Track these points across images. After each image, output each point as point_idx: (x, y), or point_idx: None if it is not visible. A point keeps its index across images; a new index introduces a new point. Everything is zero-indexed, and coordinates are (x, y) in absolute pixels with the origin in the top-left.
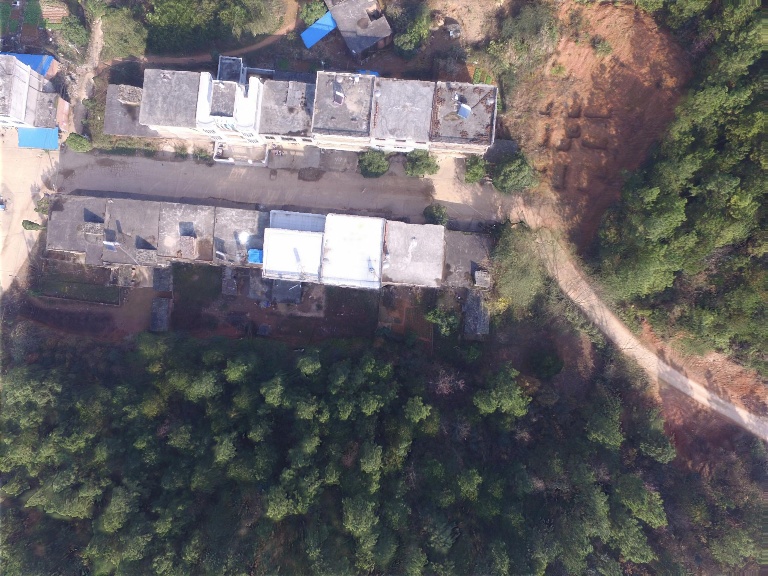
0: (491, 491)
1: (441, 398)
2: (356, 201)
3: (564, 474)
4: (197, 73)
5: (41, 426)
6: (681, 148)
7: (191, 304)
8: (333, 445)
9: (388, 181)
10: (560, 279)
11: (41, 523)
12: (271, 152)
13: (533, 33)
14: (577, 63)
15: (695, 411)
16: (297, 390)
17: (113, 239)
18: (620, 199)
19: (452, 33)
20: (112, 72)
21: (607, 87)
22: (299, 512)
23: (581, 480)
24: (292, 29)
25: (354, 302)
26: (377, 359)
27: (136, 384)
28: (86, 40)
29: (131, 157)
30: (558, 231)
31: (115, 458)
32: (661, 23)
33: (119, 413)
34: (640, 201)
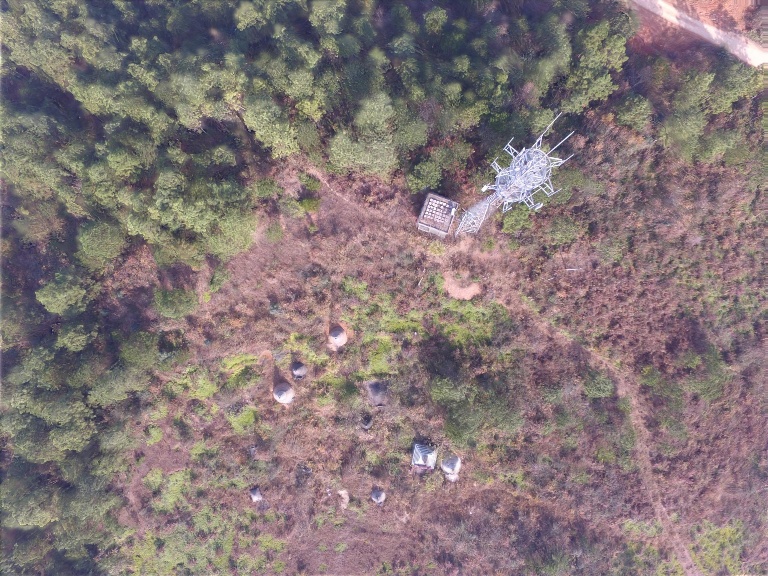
0: (455, 24)
1: None
2: None
3: (529, 31)
4: None
5: (26, 1)
6: None
7: None
8: None
9: None
10: None
11: (25, 89)
12: None
13: None
14: None
15: (664, 29)
16: None
17: None
18: None
19: None
20: None
21: None
22: (268, 20)
23: (545, 35)
24: None
25: None
26: None
27: None
28: None
29: None
30: None
31: (95, 20)
32: None
33: None
34: None
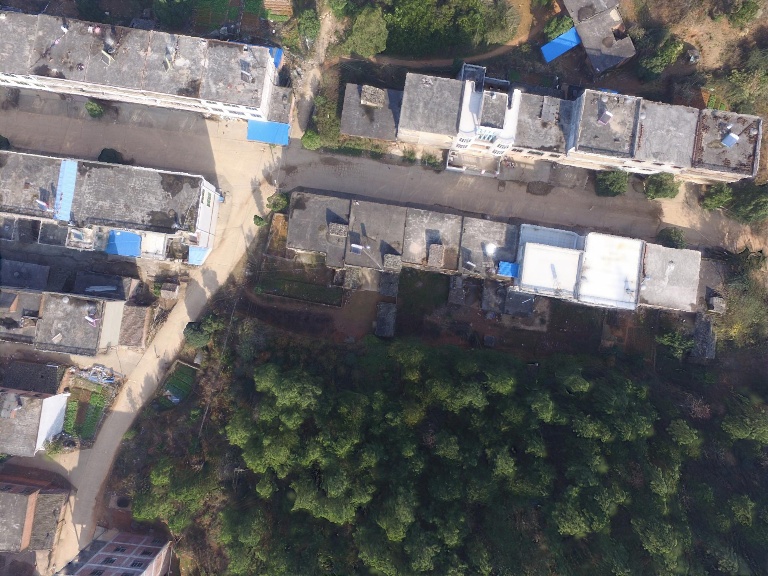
0: (763, 517)
1: (697, 422)
2: (583, 218)
3: None
4: (460, 81)
5: (299, 429)
6: None
7: (414, 310)
8: (618, 465)
9: (617, 200)
10: None
11: (297, 526)
12: (501, 163)
13: None
14: None
15: None
16: (565, 407)
17: (357, 242)
18: None
19: (693, 59)
20: (342, 70)
21: None
22: (593, 531)
23: None
24: (525, 41)
25: (578, 319)
26: None
27: (381, 390)
28: None
29: (357, 158)
30: None
31: (380, 465)
32: None
33: (379, 420)
34: None
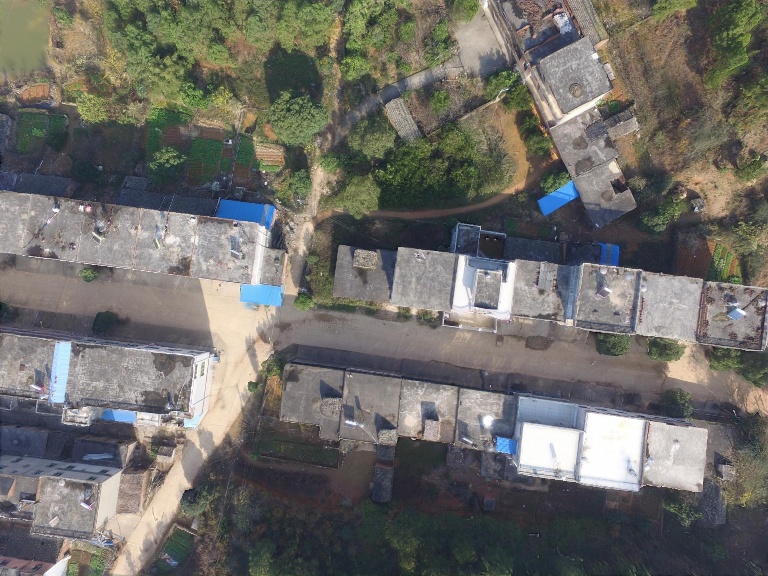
0: None
1: None
2: (585, 373)
3: None
4: (453, 254)
5: None
6: None
7: (412, 472)
8: None
9: (619, 355)
10: None
11: None
12: None
13: None
14: None
15: None
16: None
17: (351, 415)
18: None
19: (697, 209)
20: (335, 225)
21: None
22: None
23: None
24: (521, 189)
25: None
26: (636, 565)
27: (378, 572)
28: None
29: (351, 314)
30: None
31: None
32: None
33: None
34: None
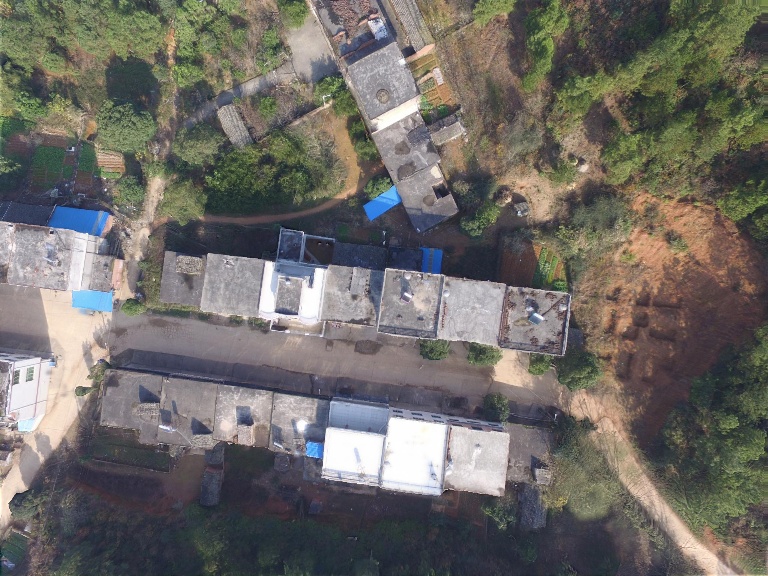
0: None
1: None
2: (413, 377)
3: None
4: (261, 260)
5: None
6: (761, 374)
7: (242, 475)
8: None
9: (447, 359)
10: (620, 472)
11: None
12: (328, 323)
13: (607, 226)
14: (649, 252)
15: None
16: None
17: (168, 420)
18: (688, 400)
19: (520, 213)
20: (168, 231)
21: (679, 278)
22: None
23: None
24: (353, 193)
25: None
26: (436, 569)
27: (189, 575)
28: (142, 195)
29: (185, 319)
30: (620, 422)
31: None
32: (742, 228)
33: None
34: (715, 422)
